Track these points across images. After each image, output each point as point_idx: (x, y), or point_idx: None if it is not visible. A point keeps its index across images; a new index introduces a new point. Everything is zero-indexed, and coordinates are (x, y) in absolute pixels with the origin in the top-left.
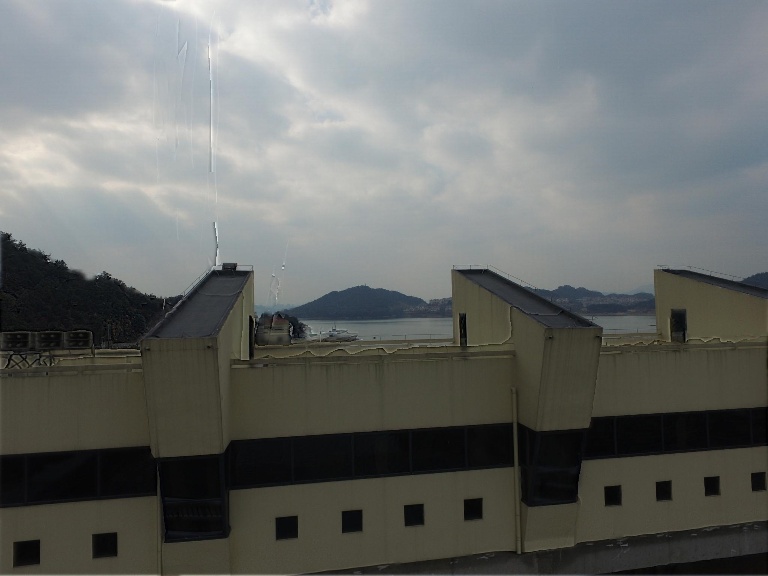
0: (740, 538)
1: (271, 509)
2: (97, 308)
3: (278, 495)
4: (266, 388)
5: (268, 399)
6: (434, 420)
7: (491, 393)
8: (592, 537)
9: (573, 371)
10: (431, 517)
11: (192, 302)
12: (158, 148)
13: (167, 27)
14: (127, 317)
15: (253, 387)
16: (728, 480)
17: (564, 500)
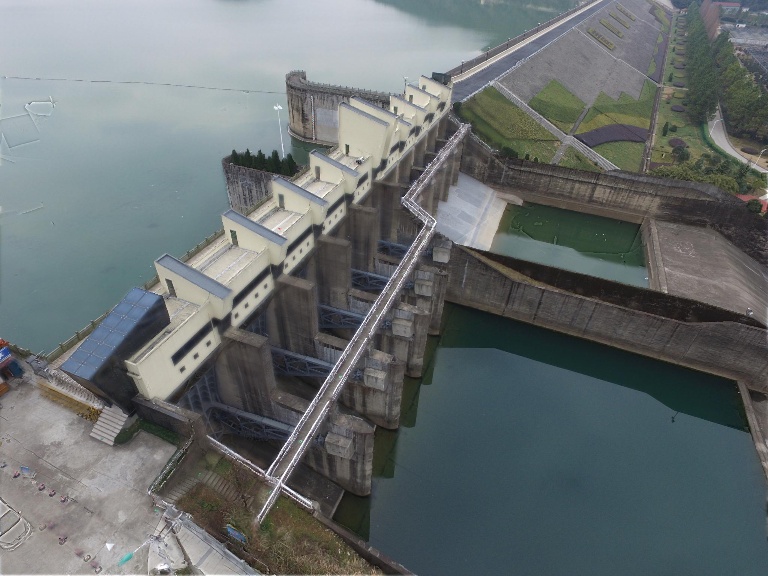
0: None
1: None
2: None
3: None
4: None
5: None
6: None
7: None
8: None
9: None
10: None
11: None
12: None
13: None
14: None
15: None
16: None
17: None
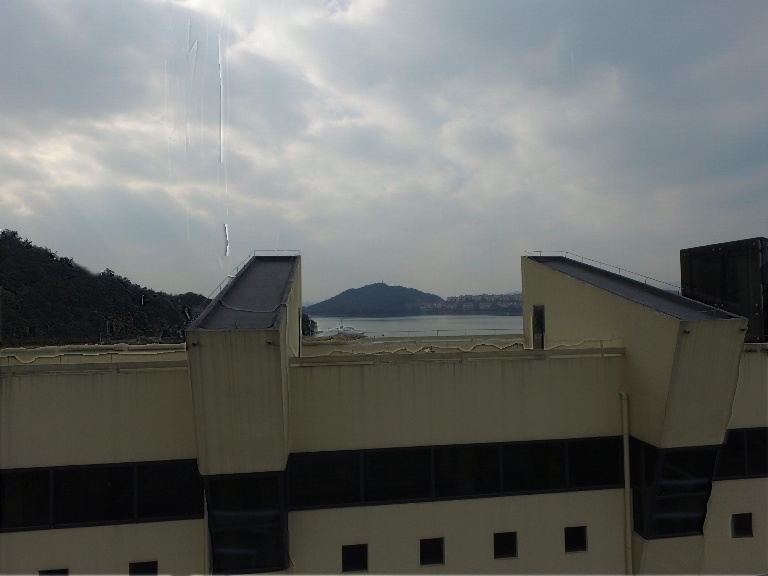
0: None
1: None
2: (98, 305)
3: None
4: None
5: None
6: (87, 454)
7: (176, 418)
8: None
9: (243, 391)
10: None
11: None
12: (170, 147)
13: (178, 26)
14: (129, 314)
15: None
16: (529, 537)
17: (266, 567)
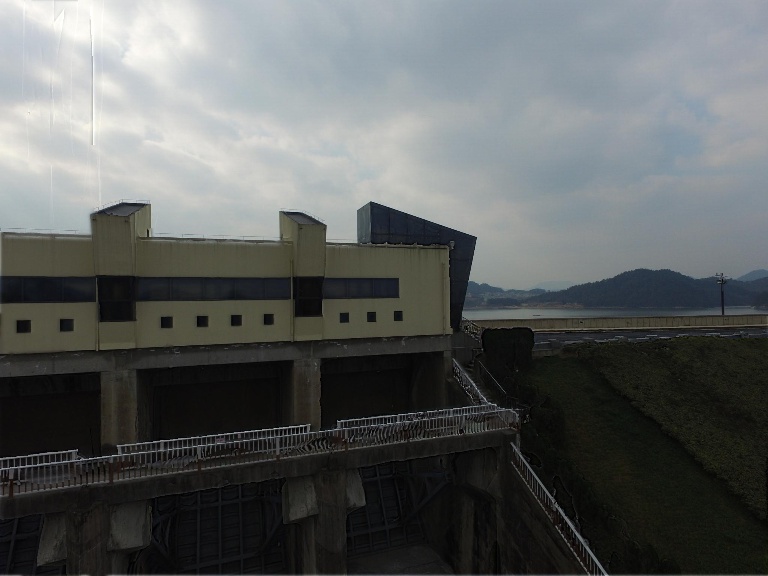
0: (258, 352)
1: None
2: None
3: None
4: None
5: None
6: (40, 272)
7: (82, 259)
8: (151, 345)
9: (115, 241)
10: (36, 328)
11: None
12: (29, 123)
13: None
14: None
15: None
16: (248, 317)
17: (125, 320)
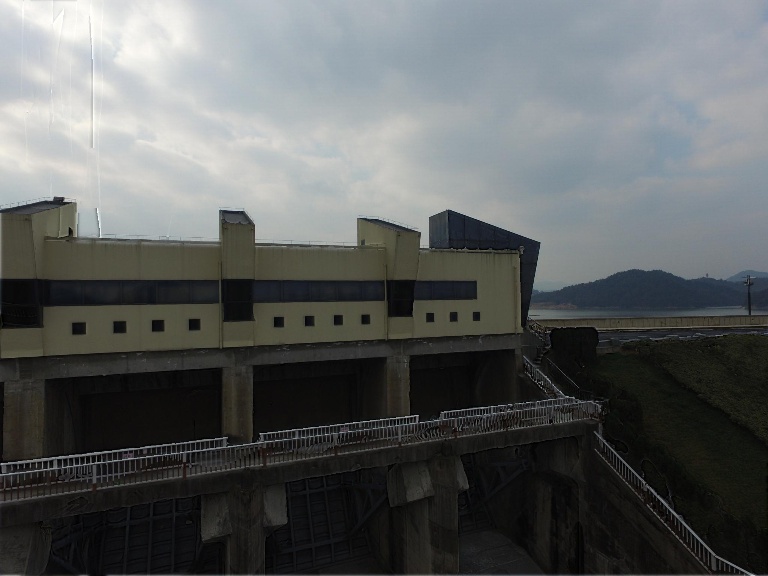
0: (356, 349)
1: (69, 318)
2: None
3: (74, 311)
4: (67, 253)
5: (68, 259)
6: (171, 276)
7: (207, 264)
8: (266, 343)
9: (241, 247)
10: (169, 327)
11: (24, 209)
12: (28, 123)
13: None
14: None
15: (59, 252)
16: (348, 318)
17: (245, 319)
